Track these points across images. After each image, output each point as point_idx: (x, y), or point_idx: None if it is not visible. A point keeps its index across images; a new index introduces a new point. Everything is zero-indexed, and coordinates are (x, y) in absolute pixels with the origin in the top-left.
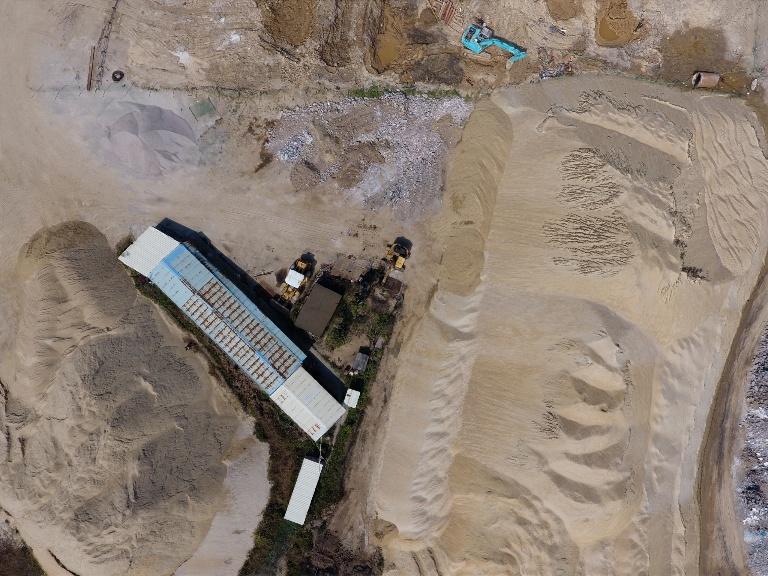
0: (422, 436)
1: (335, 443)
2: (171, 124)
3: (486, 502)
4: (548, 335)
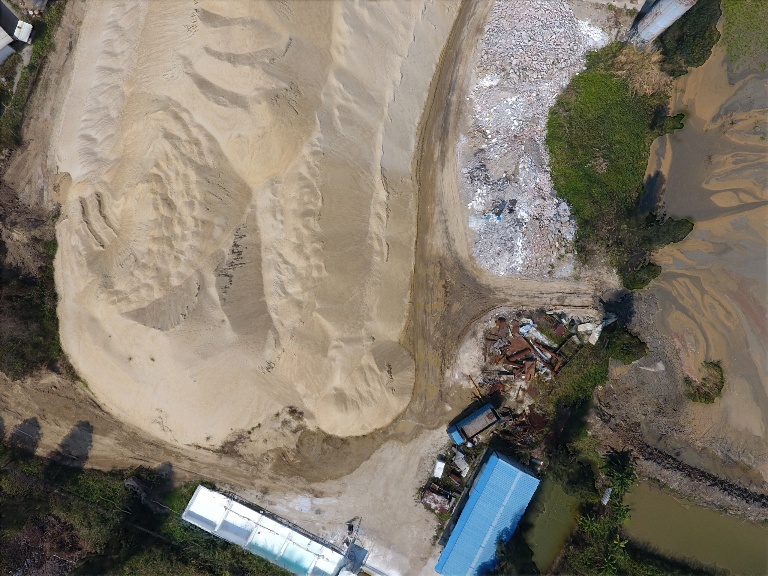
0: (93, 70)
1: (15, 91)
2: None
3: (144, 128)
4: None
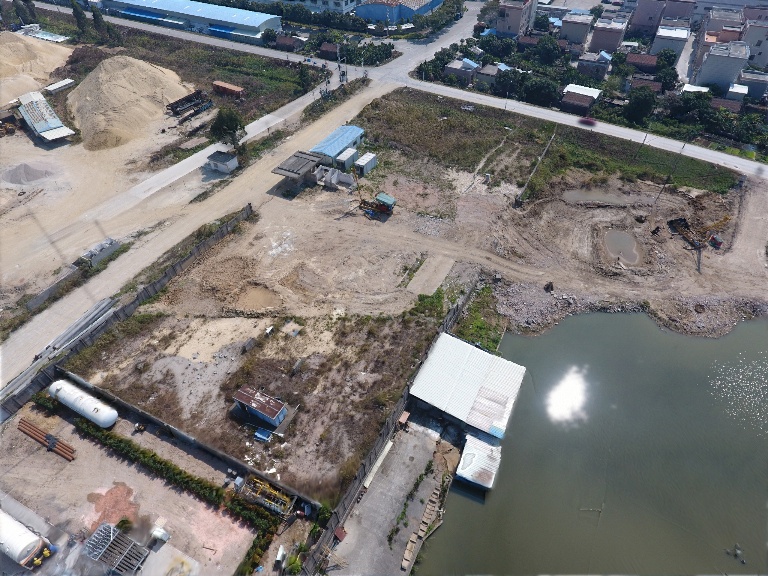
0: None
1: None
2: (9, 174)
3: None
4: None
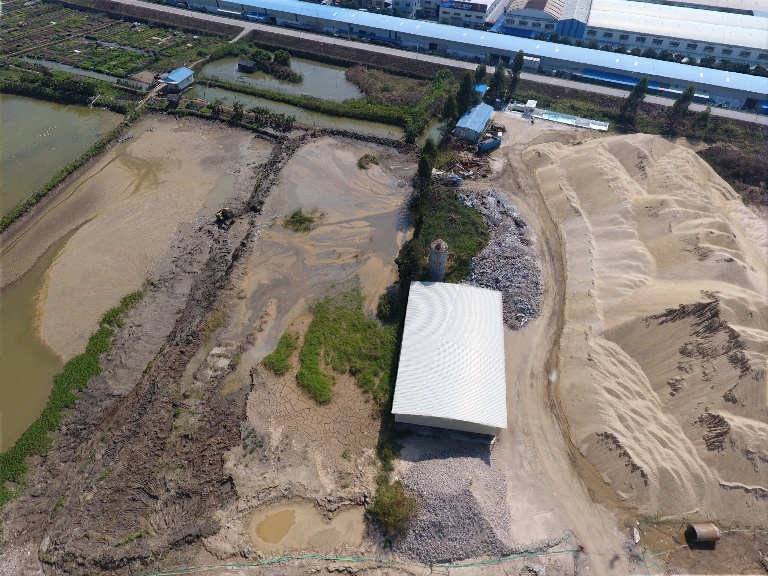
0: None
1: None
2: None
3: None
4: (762, 279)
